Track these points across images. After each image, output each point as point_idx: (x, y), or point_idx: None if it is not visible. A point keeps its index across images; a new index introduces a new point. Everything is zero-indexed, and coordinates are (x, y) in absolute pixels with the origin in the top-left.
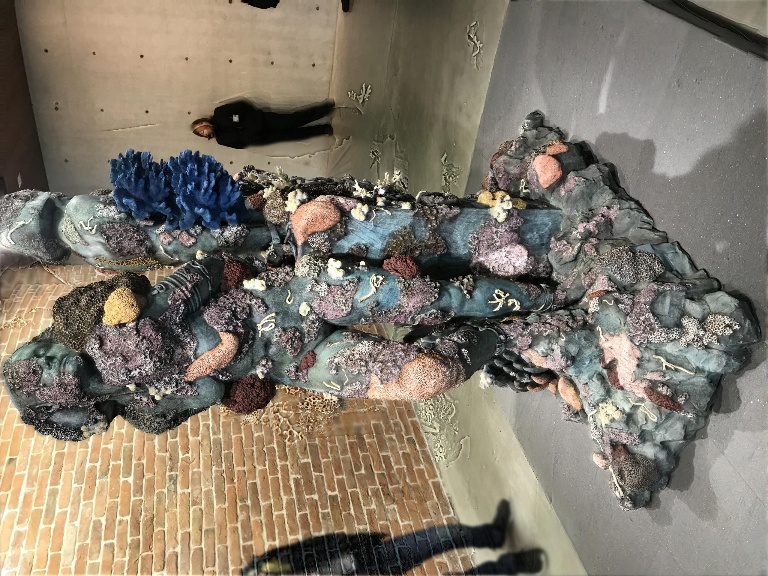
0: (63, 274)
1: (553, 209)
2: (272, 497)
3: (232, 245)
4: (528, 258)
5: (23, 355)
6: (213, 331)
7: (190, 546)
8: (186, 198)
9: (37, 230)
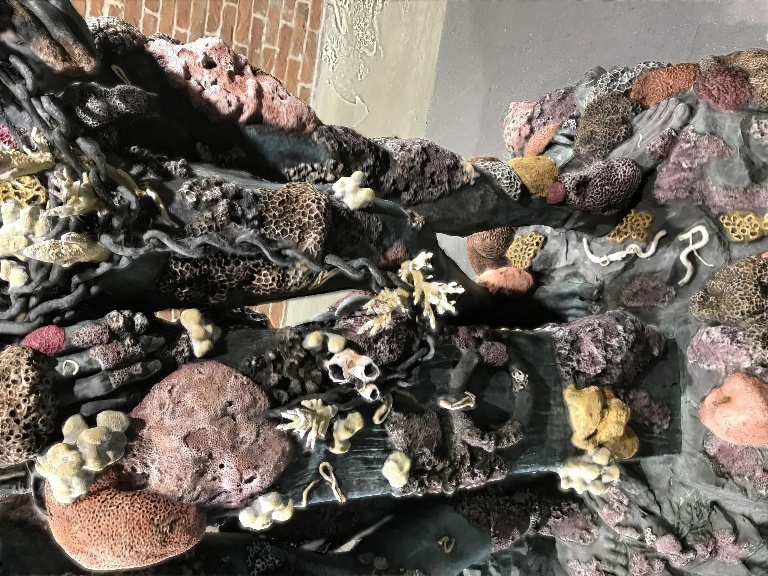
0: None
1: (669, 454)
2: None
3: None
4: None
5: None
6: None
7: None
8: None
9: None
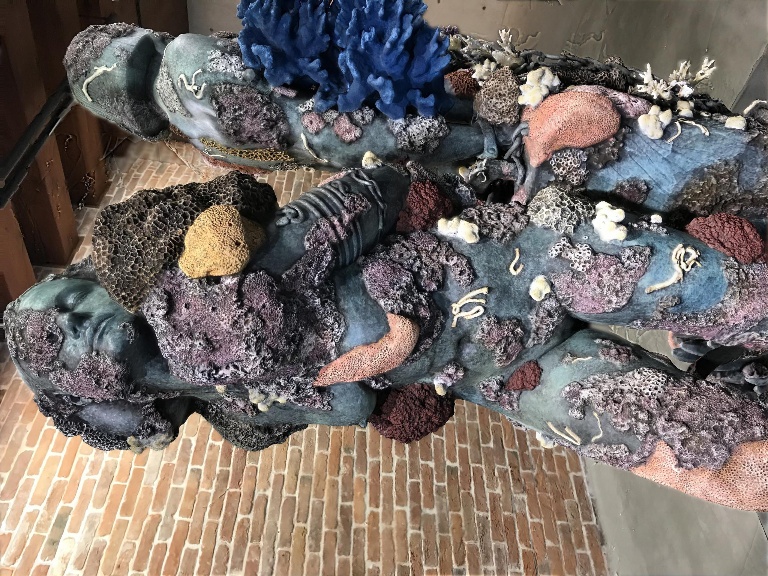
0: (188, 154)
1: None
2: (382, 454)
3: (419, 150)
4: None
5: (37, 301)
6: (377, 309)
7: (283, 492)
8: (356, 56)
9: (122, 83)
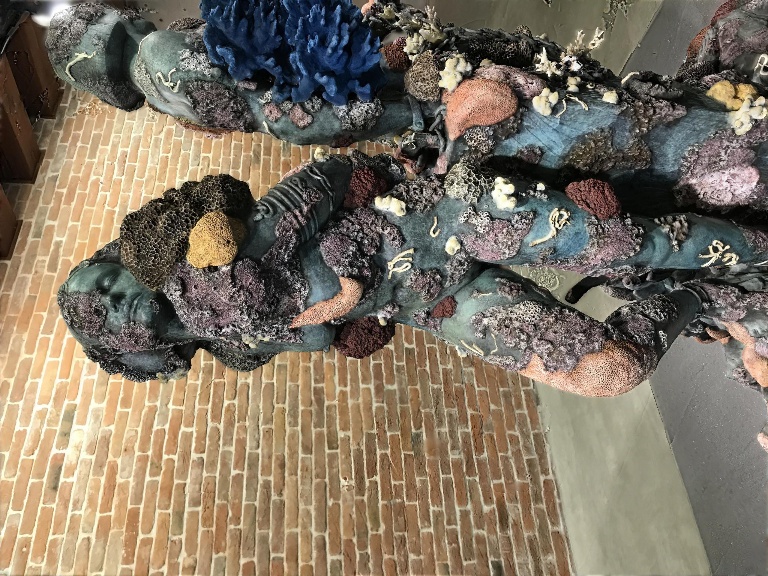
0: None
1: None
2: None
3: (360, 129)
4: (756, 185)
5: (82, 285)
6: (331, 274)
7: (262, 379)
8: (304, 56)
9: (102, 69)
